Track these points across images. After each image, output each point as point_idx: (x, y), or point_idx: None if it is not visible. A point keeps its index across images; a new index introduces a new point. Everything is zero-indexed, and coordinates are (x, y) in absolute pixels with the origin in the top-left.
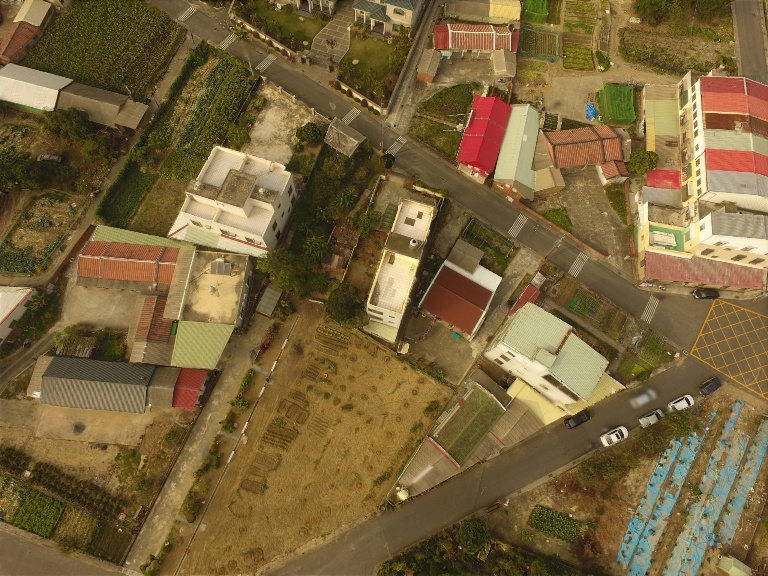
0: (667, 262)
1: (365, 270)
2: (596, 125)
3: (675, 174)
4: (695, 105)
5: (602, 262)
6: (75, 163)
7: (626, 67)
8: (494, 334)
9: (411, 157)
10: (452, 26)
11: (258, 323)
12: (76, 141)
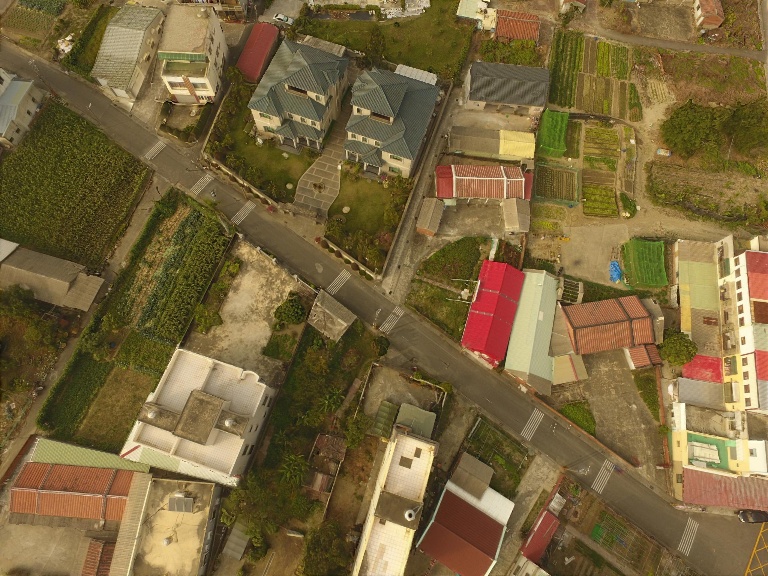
0: (709, 482)
1: (353, 490)
2: (621, 289)
3: (715, 362)
4: (739, 284)
5: (631, 472)
6: (16, 352)
7: (654, 212)
8: (505, 575)
9: (409, 334)
10: (457, 169)
11: (225, 564)
12: (20, 320)
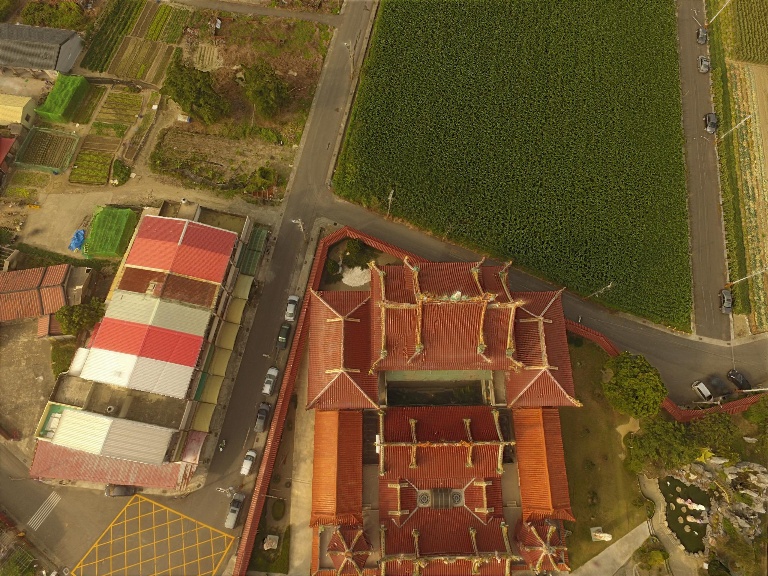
0: (61, 455)
1: None
2: (78, 258)
3: None
4: None
5: (9, 445)
6: None
7: (150, 179)
8: None
9: None
10: None
11: None
12: None
